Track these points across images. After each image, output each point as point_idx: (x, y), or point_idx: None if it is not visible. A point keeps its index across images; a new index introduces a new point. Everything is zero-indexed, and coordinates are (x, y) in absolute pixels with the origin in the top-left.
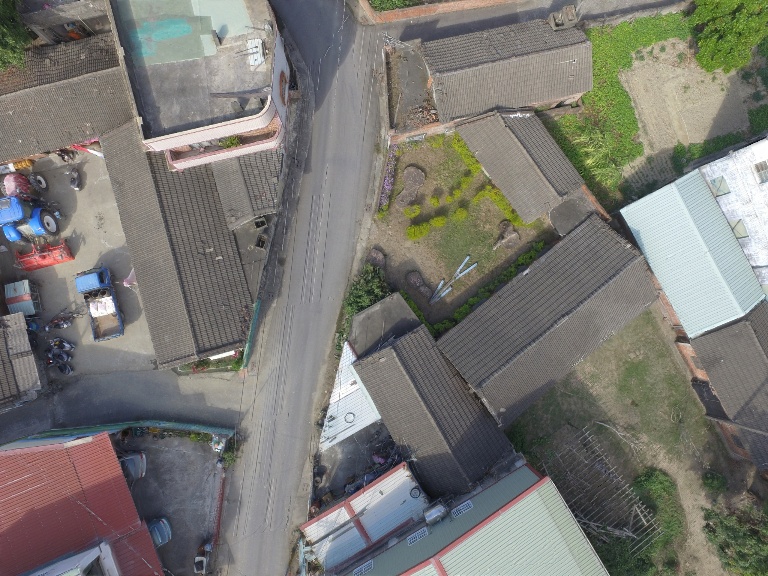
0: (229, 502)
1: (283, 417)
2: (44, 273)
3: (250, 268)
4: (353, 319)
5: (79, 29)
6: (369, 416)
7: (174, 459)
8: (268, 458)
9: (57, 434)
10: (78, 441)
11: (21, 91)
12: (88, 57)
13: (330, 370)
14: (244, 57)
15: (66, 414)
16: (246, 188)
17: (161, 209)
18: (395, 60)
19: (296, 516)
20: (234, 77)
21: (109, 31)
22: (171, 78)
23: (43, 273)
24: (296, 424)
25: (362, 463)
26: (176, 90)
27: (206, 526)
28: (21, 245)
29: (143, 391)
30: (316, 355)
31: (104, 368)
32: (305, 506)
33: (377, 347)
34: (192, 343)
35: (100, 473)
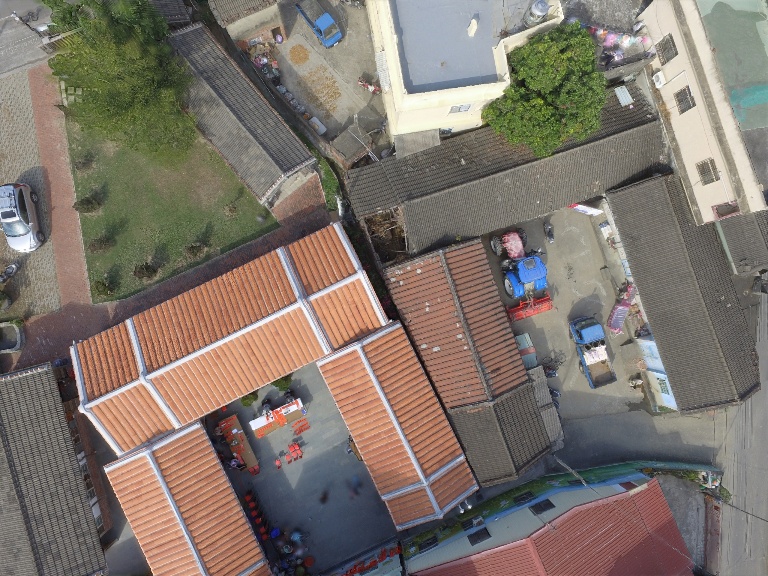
0: (712, 535)
1: (753, 451)
2: (523, 324)
3: (748, 312)
4: None
5: None
6: None
7: None
8: (743, 491)
9: (573, 480)
10: (638, 489)
11: (554, 156)
12: None
13: None
14: None
15: None
16: (763, 238)
17: (691, 263)
18: None
19: None
20: None
21: None
22: (761, 143)
23: (522, 324)
24: (765, 457)
25: None
26: (767, 154)
27: (694, 559)
28: None
29: (624, 433)
30: None
31: (584, 412)
32: None
33: None
34: (732, 390)
35: (659, 518)
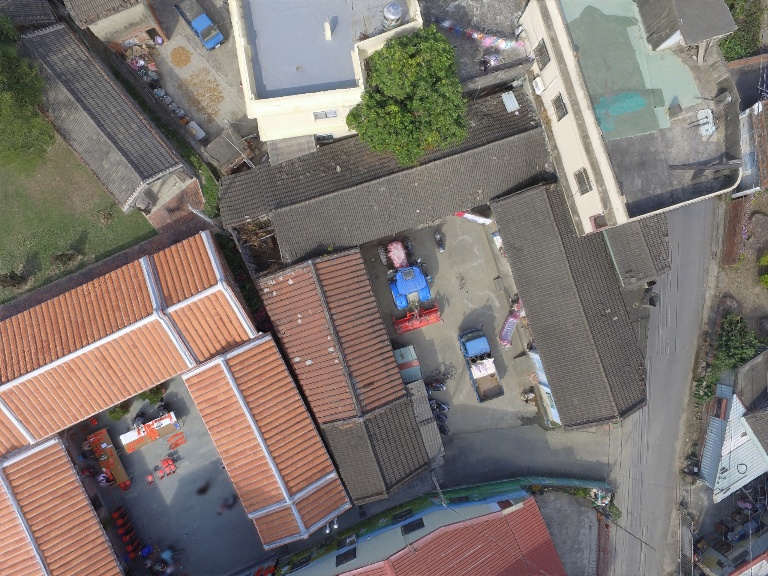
0: (605, 553)
1: (649, 467)
2: (412, 336)
3: (637, 326)
4: (738, 371)
5: (464, 96)
6: (761, 466)
7: (552, 514)
8: (638, 508)
9: (456, 497)
10: (513, 508)
11: (431, 163)
12: (480, 124)
13: (690, 418)
14: (696, 128)
15: (445, 474)
16: (648, 249)
17: (572, 275)
18: (765, 113)
19: (667, 563)
20: (688, 148)
21: (487, 96)
22: (630, 153)
23: (411, 336)
24: (662, 473)
25: (728, 508)
26: (636, 164)
27: None
28: (389, 309)
29: (515, 448)
30: (676, 404)
31: (475, 427)
32: (675, 553)
33: (766, 398)
34: (612, 406)
35: (534, 538)
